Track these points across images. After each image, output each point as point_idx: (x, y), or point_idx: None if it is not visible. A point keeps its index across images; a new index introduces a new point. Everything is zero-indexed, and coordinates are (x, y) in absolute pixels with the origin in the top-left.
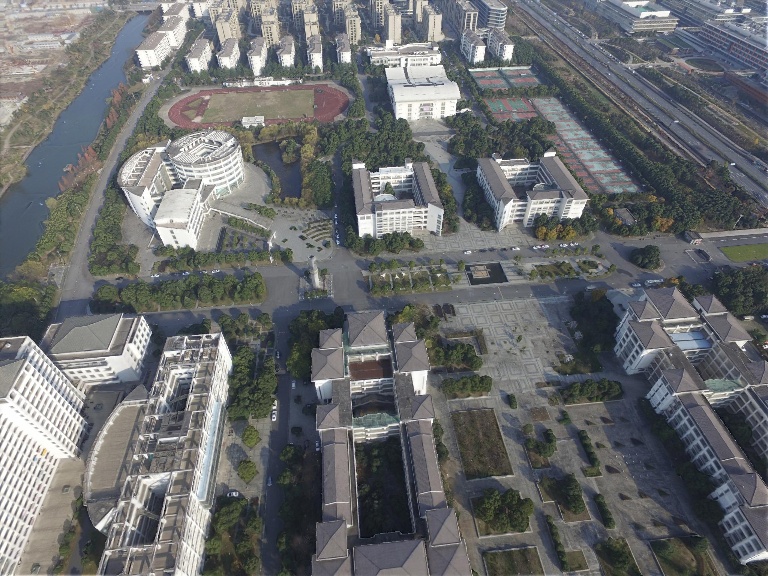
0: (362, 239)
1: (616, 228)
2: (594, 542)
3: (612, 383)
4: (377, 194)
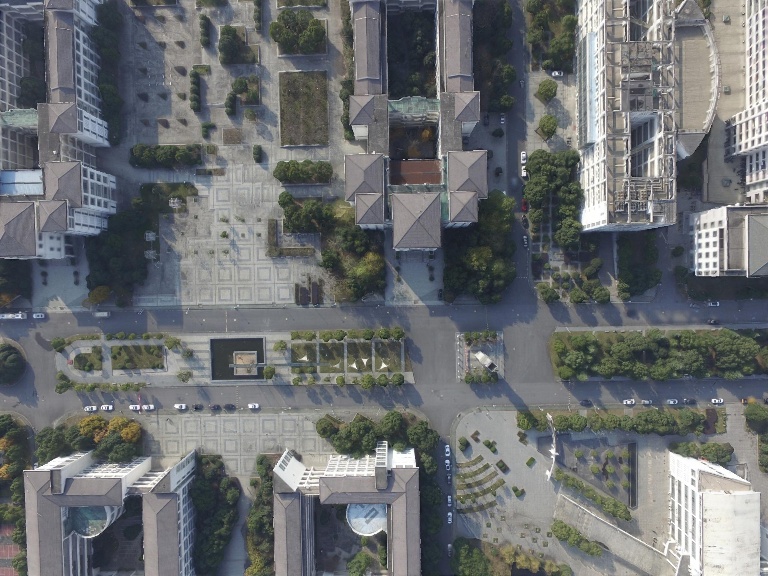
0: (411, 437)
1: (13, 429)
2: (225, 7)
3: (139, 152)
4: (377, 574)
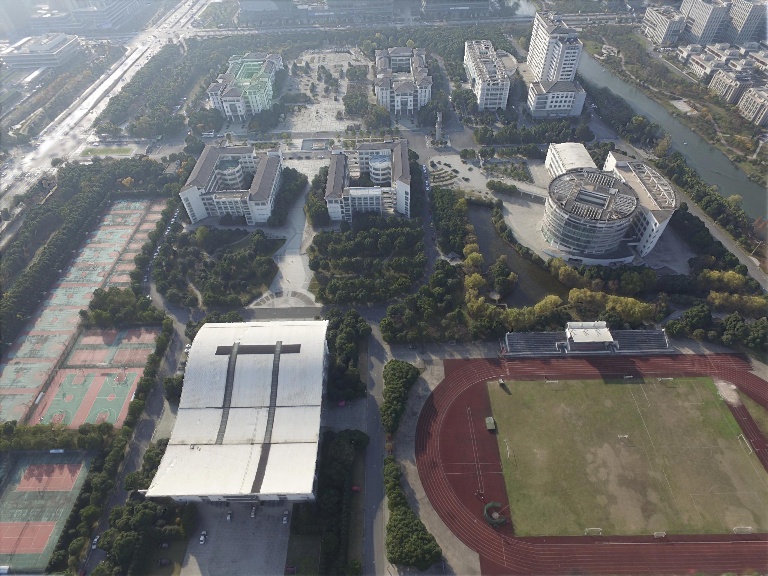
0: None
1: None
2: None
3: None
4: (385, 209)
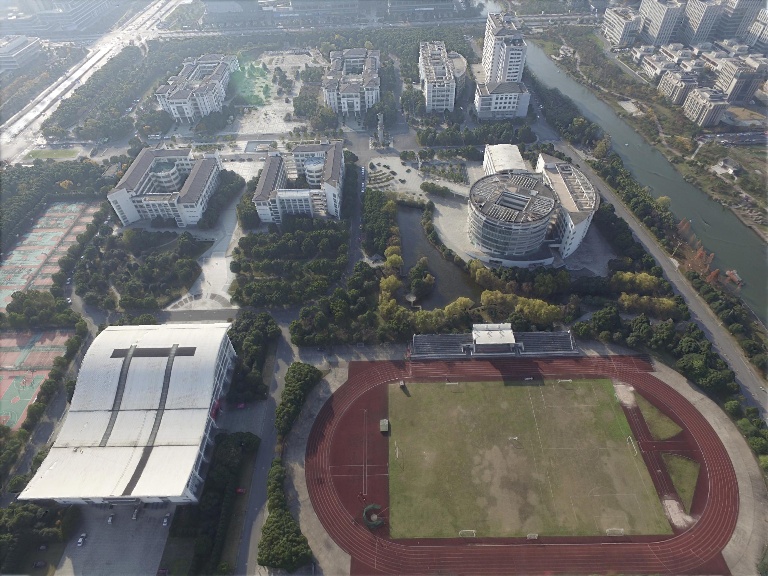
0: None
1: None
2: None
3: None
4: (317, 211)
